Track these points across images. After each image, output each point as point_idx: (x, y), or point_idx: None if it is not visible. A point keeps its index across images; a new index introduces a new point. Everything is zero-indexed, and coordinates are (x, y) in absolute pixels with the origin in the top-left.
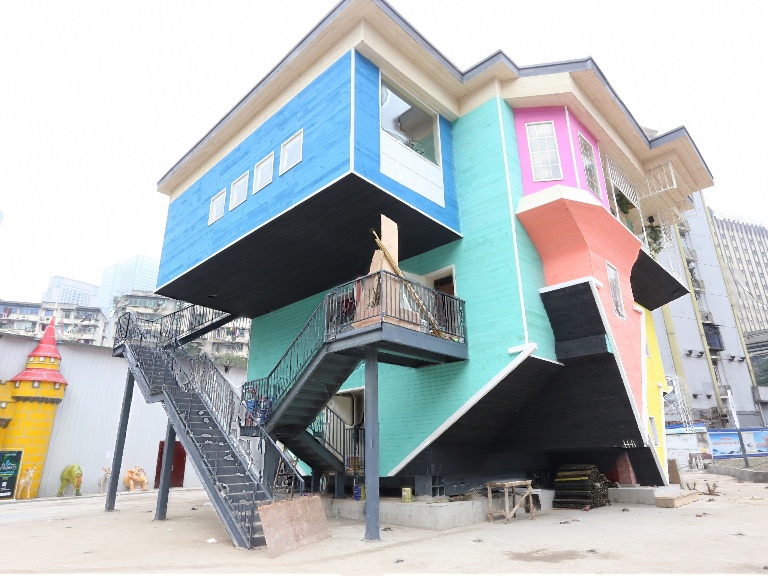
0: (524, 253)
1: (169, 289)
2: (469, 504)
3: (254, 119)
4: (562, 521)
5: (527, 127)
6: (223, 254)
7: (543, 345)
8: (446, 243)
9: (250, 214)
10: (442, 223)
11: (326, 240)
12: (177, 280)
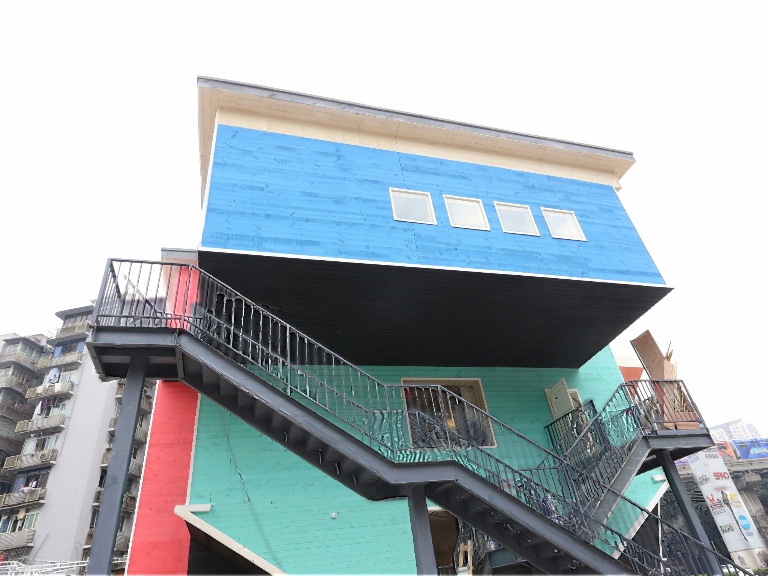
0: None
1: (246, 262)
2: None
3: (466, 150)
4: None
5: None
6: (452, 274)
7: None
8: (565, 367)
9: (509, 252)
10: None
11: (538, 320)
12: (306, 261)
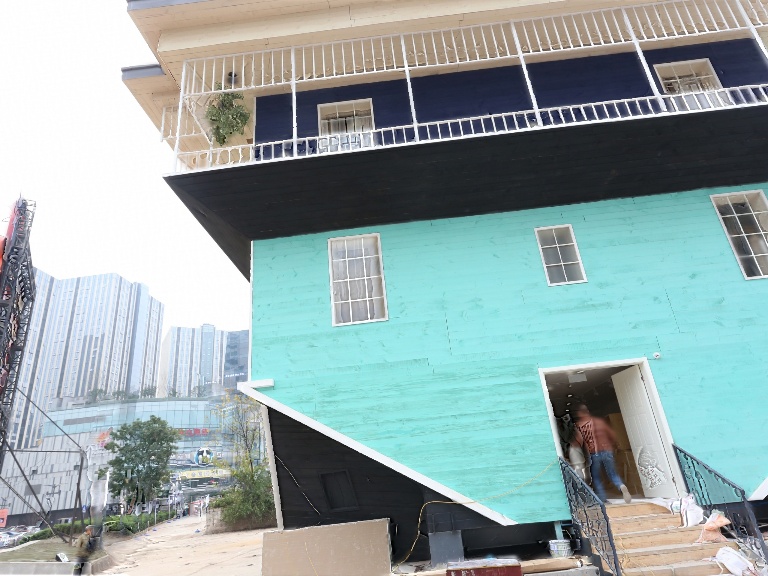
0: None
1: None
2: None
3: None
4: None
5: None
6: None
7: None
8: None
9: None
10: None
11: None
12: None
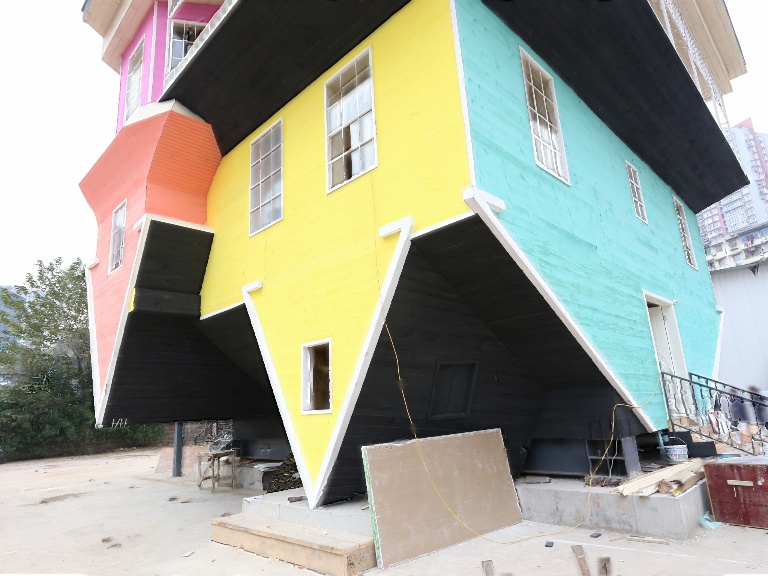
0: None
1: None
2: (214, 466)
3: None
4: (187, 499)
5: None
6: None
7: None
8: None
9: None
10: None
11: None
12: None
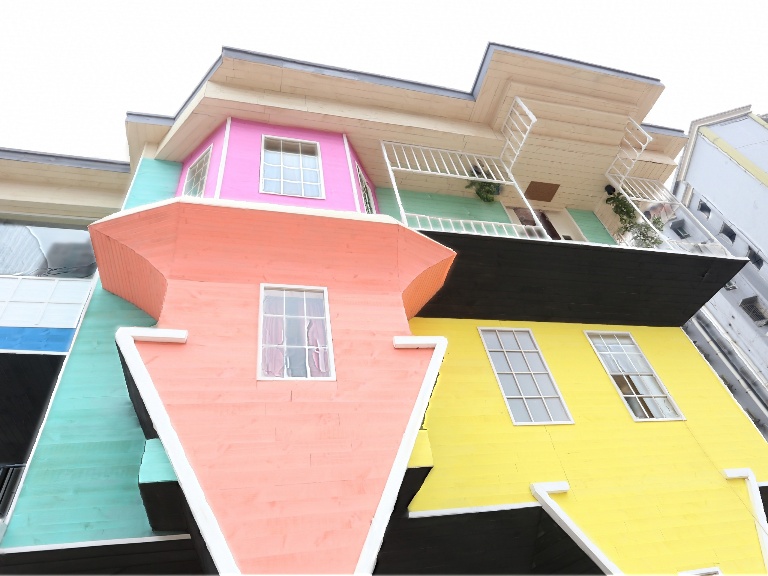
0: (104, 341)
1: None
2: None
3: None
4: None
5: (188, 171)
6: None
7: (92, 510)
8: None
9: None
10: (47, 351)
11: None
12: None
